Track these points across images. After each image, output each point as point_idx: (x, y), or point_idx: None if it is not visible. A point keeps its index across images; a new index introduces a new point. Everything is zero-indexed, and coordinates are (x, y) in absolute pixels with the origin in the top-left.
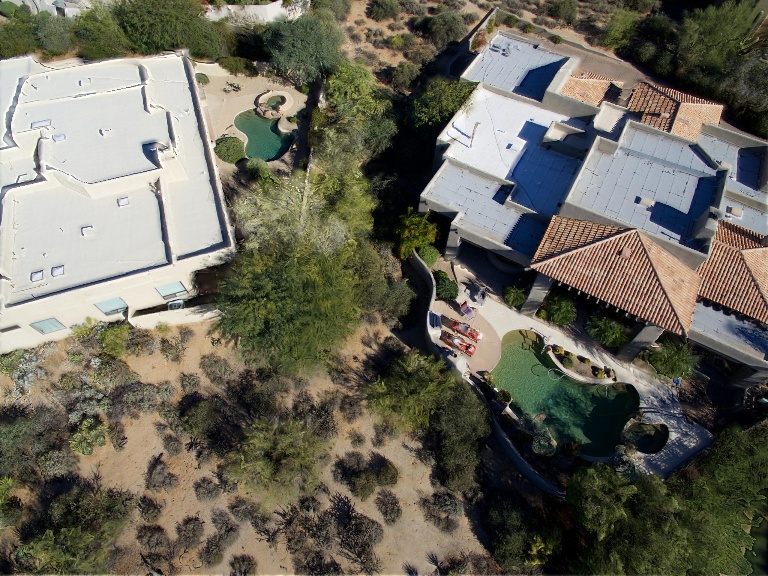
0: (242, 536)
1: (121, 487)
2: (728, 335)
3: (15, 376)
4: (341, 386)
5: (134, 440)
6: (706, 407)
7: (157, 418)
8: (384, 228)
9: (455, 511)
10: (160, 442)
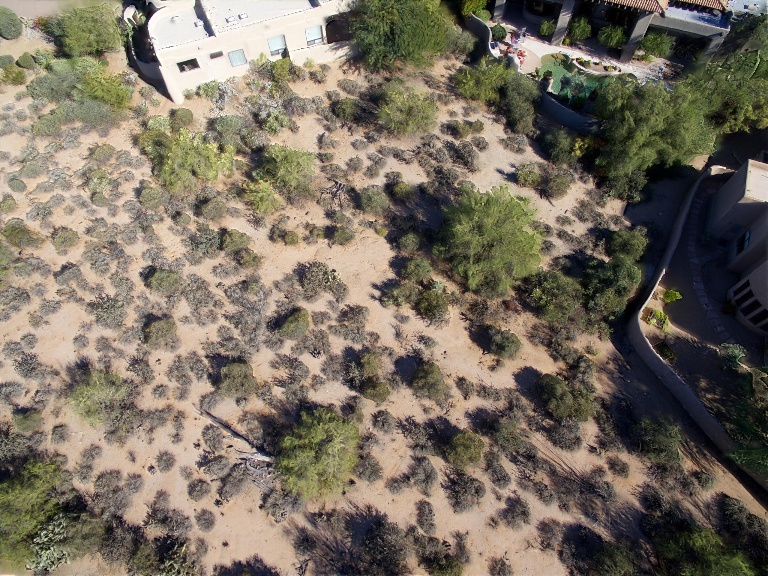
0: (389, 163)
1: (303, 150)
2: (693, 21)
3: (214, 100)
4: (436, 90)
5: (304, 127)
6: (682, 80)
7: (316, 116)
8: (448, 4)
9: (523, 141)
10: (321, 128)
